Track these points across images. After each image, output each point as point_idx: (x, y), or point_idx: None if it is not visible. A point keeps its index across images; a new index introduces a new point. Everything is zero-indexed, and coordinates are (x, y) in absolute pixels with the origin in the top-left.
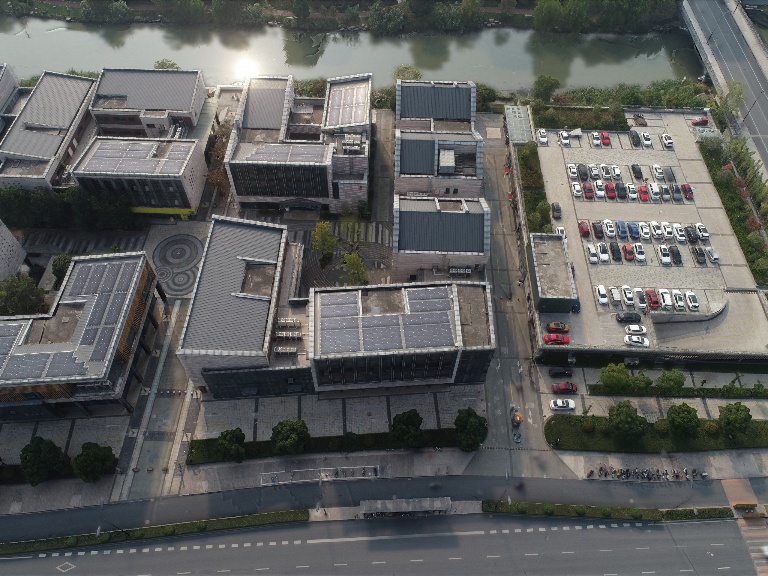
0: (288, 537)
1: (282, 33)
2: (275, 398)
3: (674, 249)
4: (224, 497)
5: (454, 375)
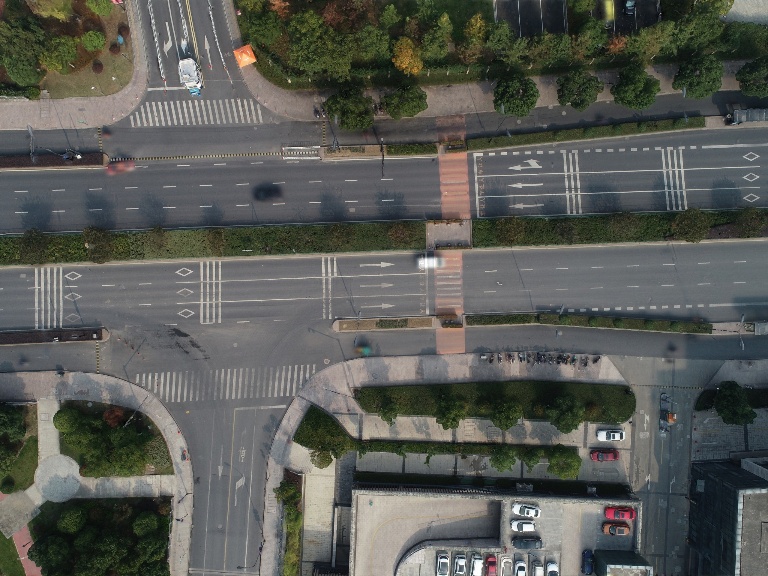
0: None
1: None
2: None
3: None
4: None
5: None
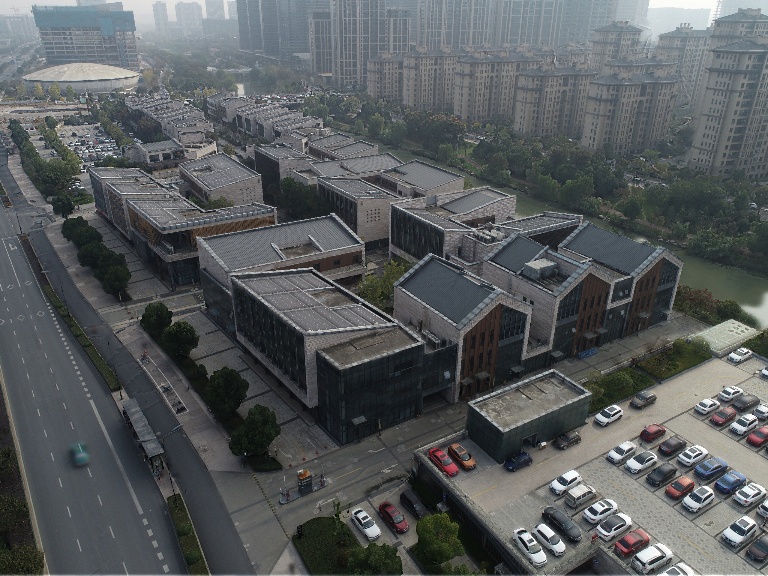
0: (92, 389)
1: (602, 224)
2: (226, 337)
3: (766, 536)
4: (119, 348)
5: (308, 390)
